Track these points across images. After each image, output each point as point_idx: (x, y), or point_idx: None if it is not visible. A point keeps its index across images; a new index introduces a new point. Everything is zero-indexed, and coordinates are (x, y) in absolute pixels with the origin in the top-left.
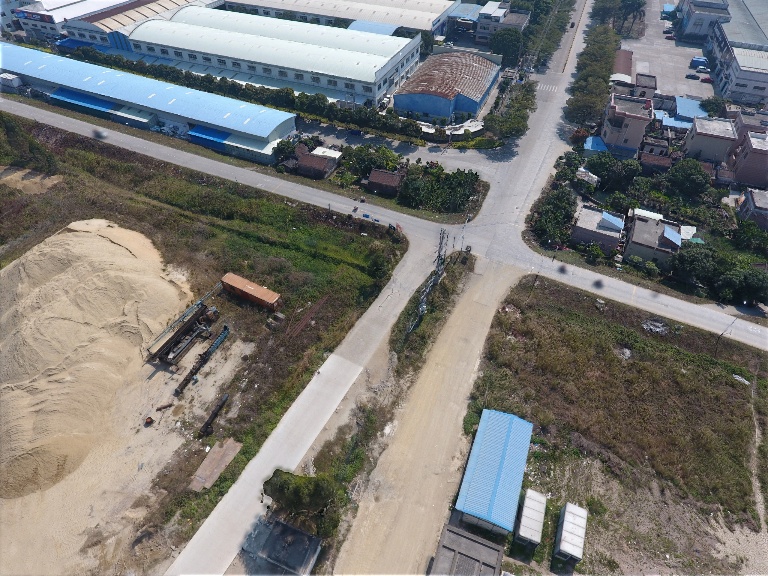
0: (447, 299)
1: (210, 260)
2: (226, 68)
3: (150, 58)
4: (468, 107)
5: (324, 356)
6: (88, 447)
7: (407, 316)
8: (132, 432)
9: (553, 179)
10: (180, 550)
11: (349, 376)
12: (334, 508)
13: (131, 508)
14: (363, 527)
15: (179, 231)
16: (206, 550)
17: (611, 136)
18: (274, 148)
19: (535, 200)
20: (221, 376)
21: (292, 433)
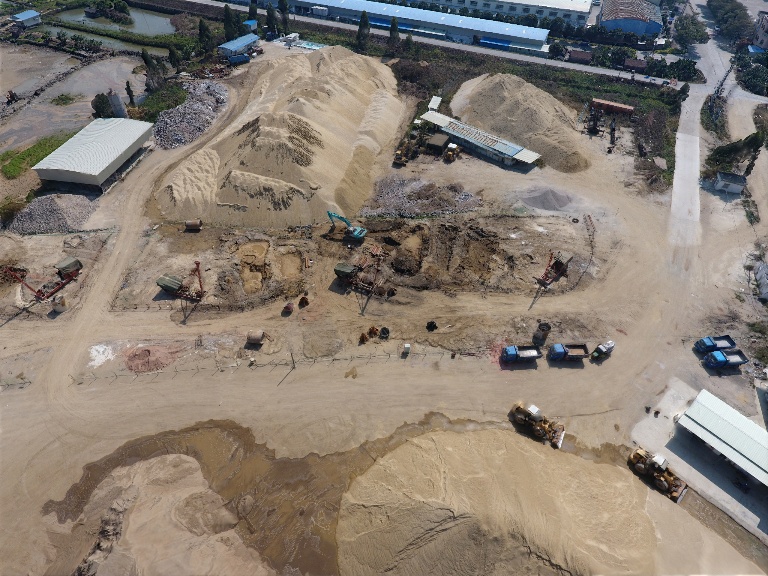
0: (722, 113)
1: (567, 97)
2: (463, 6)
3: (398, 0)
4: (654, 30)
5: (674, 133)
6: (589, 159)
7: (707, 118)
8: (604, 155)
9: (736, 68)
10: (671, 187)
11: (695, 139)
12: (757, 156)
13: (635, 175)
14: (751, 181)
15: (535, 85)
16: (684, 187)
17: (767, 42)
18: (551, 48)
19: (735, 76)
20: (627, 138)
21: (686, 156)
